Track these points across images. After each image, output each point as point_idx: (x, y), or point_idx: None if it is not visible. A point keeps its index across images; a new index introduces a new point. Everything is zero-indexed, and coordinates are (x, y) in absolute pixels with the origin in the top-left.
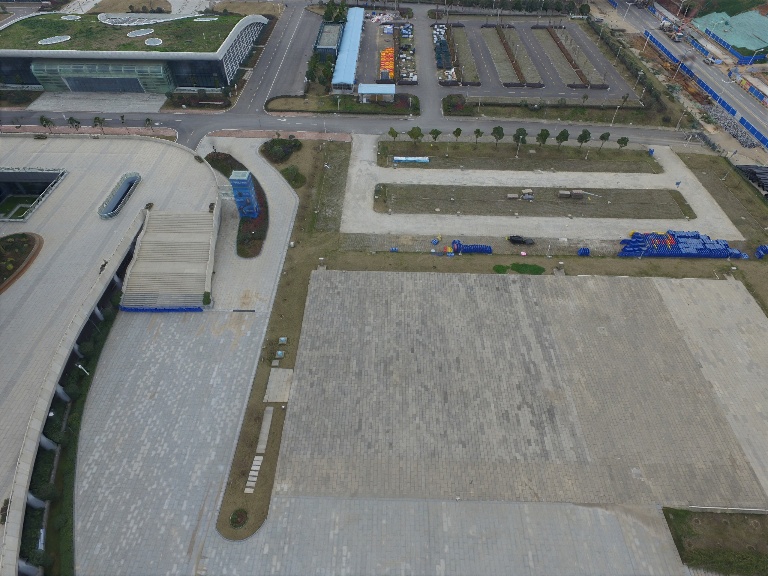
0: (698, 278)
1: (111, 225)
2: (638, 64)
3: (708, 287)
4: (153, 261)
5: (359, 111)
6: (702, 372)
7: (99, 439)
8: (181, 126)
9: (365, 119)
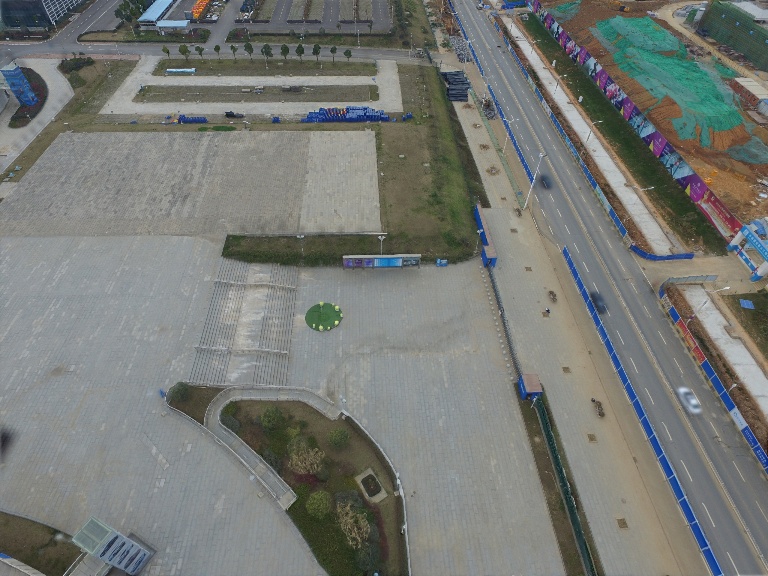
0: (345, 131)
1: None
2: (416, 8)
3: (348, 135)
4: None
5: (154, 40)
6: (306, 176)
7: None
8: (0, 52)
9: (158, 46)
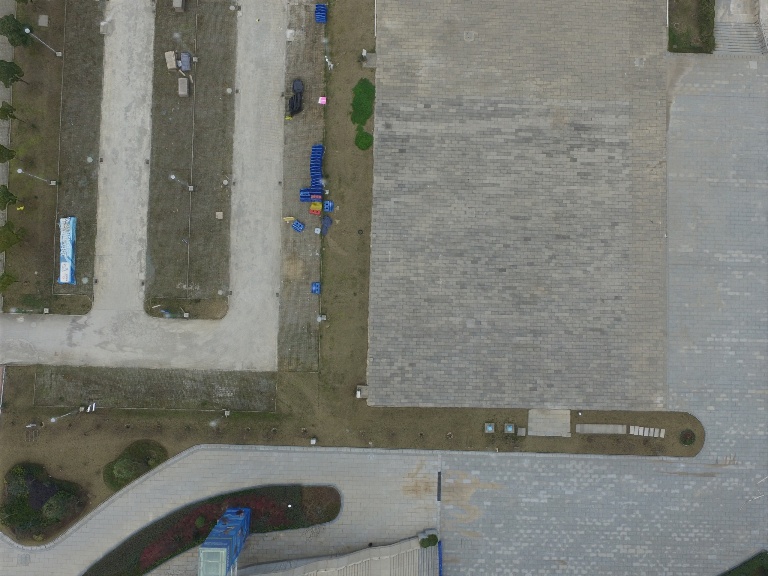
0: None
1: None
2: None
3: None
4: None
5: None
6: None
7: None
8: None
9: None
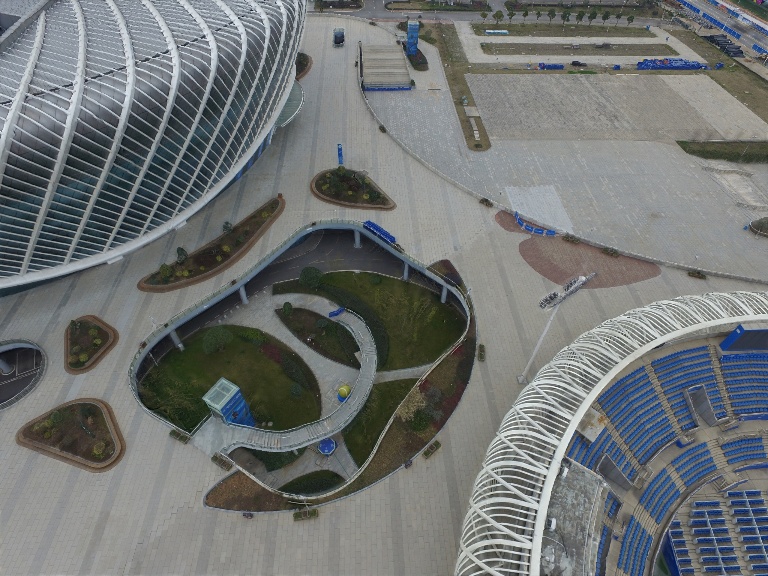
0: (684, 75)
1: (344, 50)
2: None
3: (689, 77)
4: (373, 68)
5: (451, 9)
6: (689, 104)
7: (391, 128)
8: None
9: (457, 13)
